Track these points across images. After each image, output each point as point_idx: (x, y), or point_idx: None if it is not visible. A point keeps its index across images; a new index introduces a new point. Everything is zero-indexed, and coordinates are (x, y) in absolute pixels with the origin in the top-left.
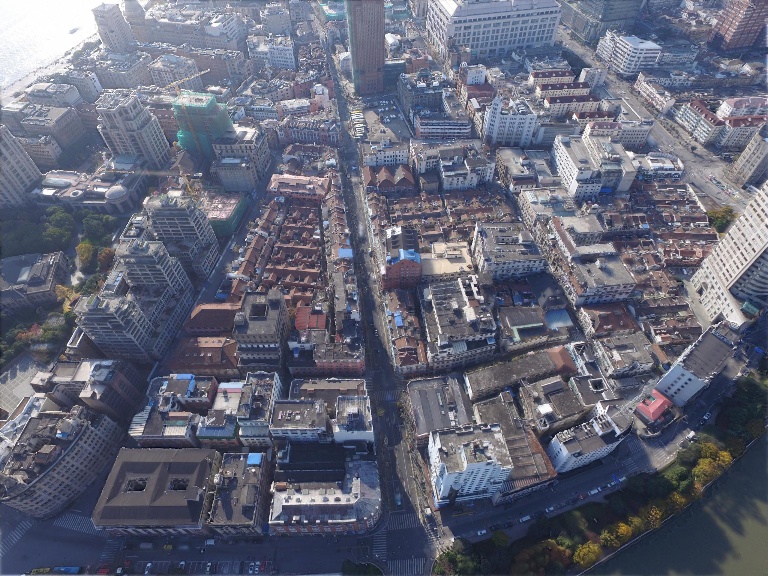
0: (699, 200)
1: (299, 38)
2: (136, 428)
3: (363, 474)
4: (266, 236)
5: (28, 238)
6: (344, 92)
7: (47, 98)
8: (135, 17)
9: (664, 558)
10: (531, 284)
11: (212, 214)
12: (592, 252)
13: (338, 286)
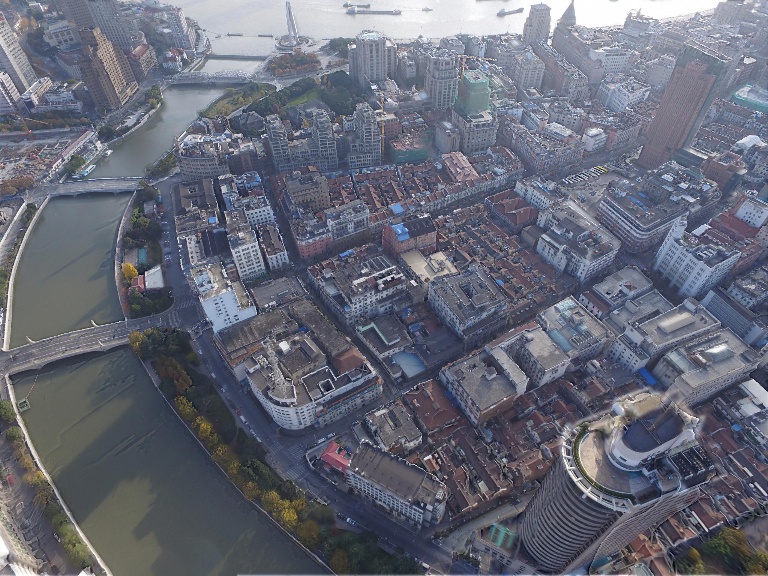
0: (757, 516)
1: (658, 94)
2: (223, 177)
3: (210, 263)
4: (400, 175)
5: (336, 98)
6: (629, 154)
7: (446, 46)
8: (563, 24)
9: (196, 477)
10: (439, 332)
11: (397, 143)
12: (501, 362)
13: (347, 205)
